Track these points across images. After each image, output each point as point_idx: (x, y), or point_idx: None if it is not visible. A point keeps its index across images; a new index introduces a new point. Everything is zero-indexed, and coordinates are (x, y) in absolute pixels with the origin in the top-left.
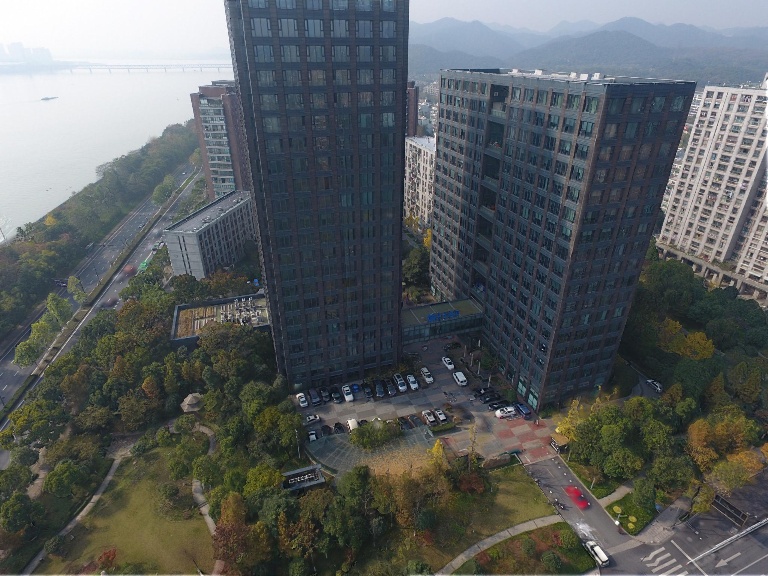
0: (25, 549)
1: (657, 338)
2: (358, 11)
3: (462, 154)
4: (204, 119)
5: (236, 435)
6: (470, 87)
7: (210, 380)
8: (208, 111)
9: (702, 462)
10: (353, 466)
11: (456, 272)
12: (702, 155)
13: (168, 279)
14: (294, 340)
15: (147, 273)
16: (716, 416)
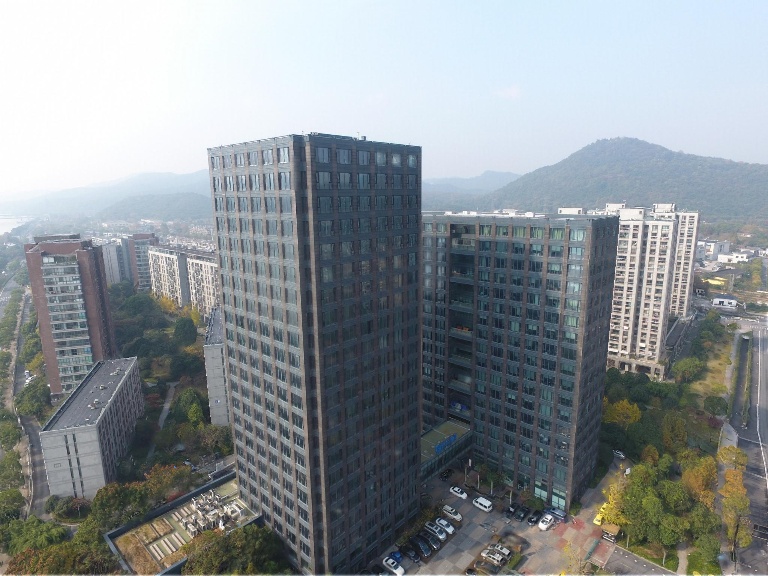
0: None
1: None
2: (394, 167)
3: None
4: (48, 281)
5: None
6: None
7: None
8: (55, 271)
9: (709, 504)
10: None
11: (423, 397)
12: None
13: (29, 505)
14: (336, 520)
15: None
16: (687, 462)
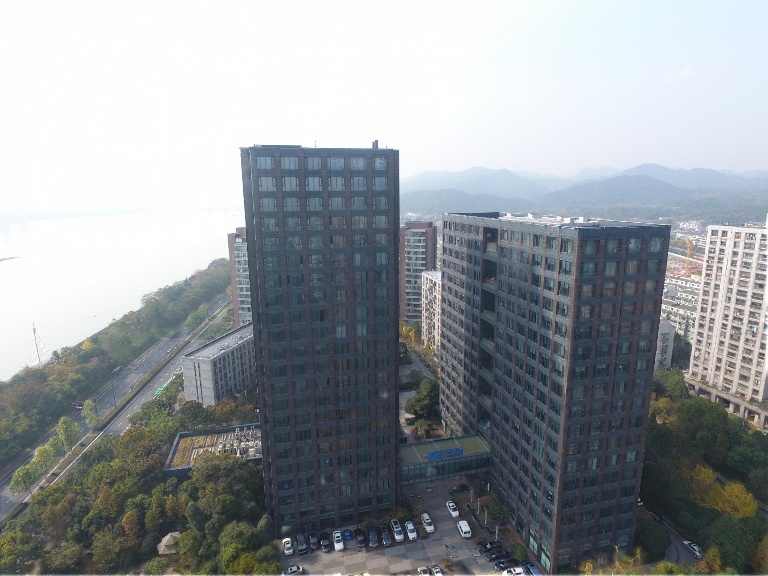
0: None
1: (690, 489)
2: (353, 170)
3: (463, 288)
4: (237, 255)
5: None
6: (467, 229)
7: (192, 518)
8: (241, 248)
9: None
10: None
11: (463, 406)
12: (718, 289)
13: (181, 405)
14: (283, 475)
15: (161, 398)
16: None
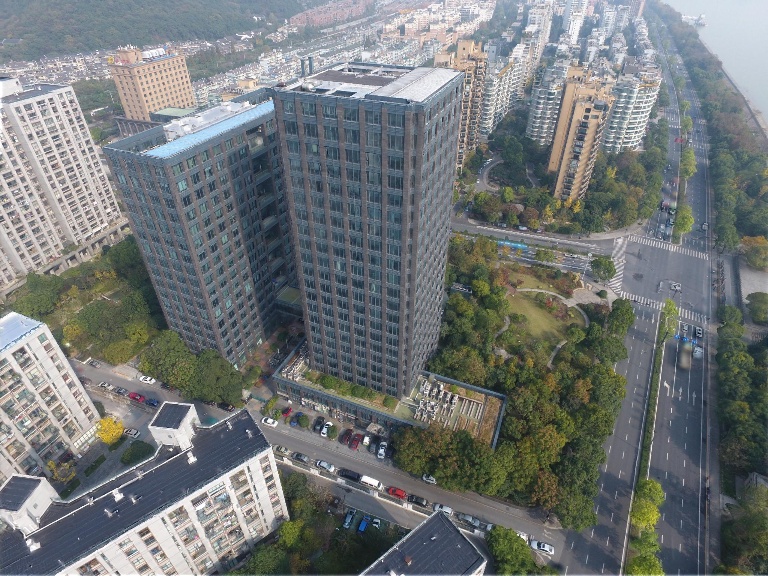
0: None
1: None
2: None
3: (232, 210)
4: None
5: None
6: None
7: None
8: None
9: None
10: None
11: (258, 303)
12: None
13: None
14: None
15: None
16: None
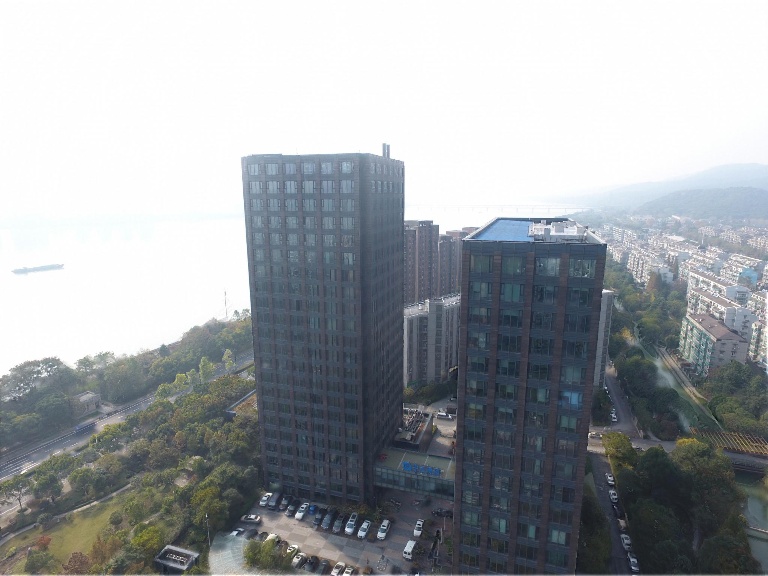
0: (37, 514)
1: None
2: (322, 174)
3: None
4: None
5: (179, 498)
6: None
7: (212, 450)
8: None
9: None
10: (222, 573)
11: None
12: None
13: None
14: (270, 438)
15: None
16: None
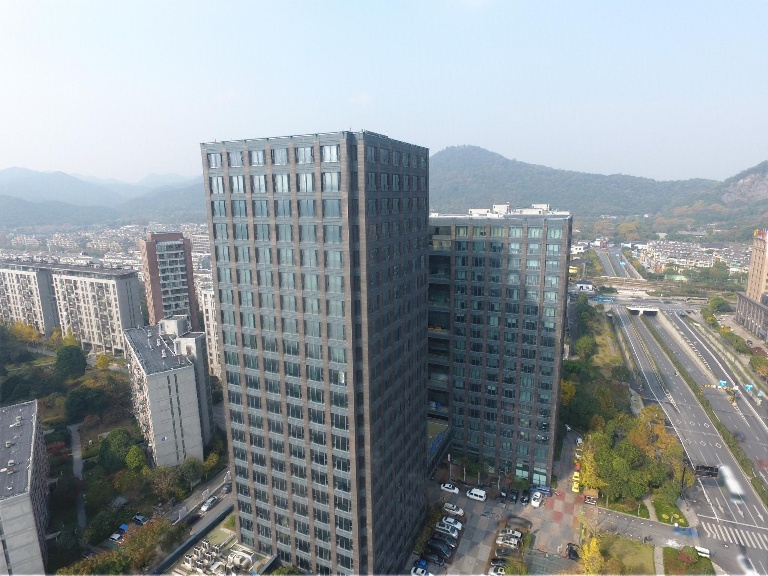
0: None
1: None
2: (413, 168)
3: None
4: None
5: None
6: None
7: None
8: None
9: (653, 456)
10: None
11: None
12: None
13: None
14: (378, 541)
15: None
16: None
